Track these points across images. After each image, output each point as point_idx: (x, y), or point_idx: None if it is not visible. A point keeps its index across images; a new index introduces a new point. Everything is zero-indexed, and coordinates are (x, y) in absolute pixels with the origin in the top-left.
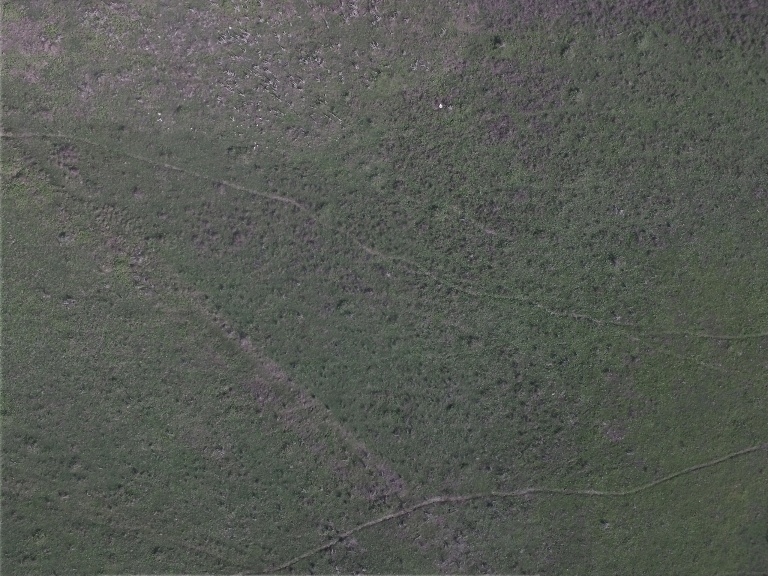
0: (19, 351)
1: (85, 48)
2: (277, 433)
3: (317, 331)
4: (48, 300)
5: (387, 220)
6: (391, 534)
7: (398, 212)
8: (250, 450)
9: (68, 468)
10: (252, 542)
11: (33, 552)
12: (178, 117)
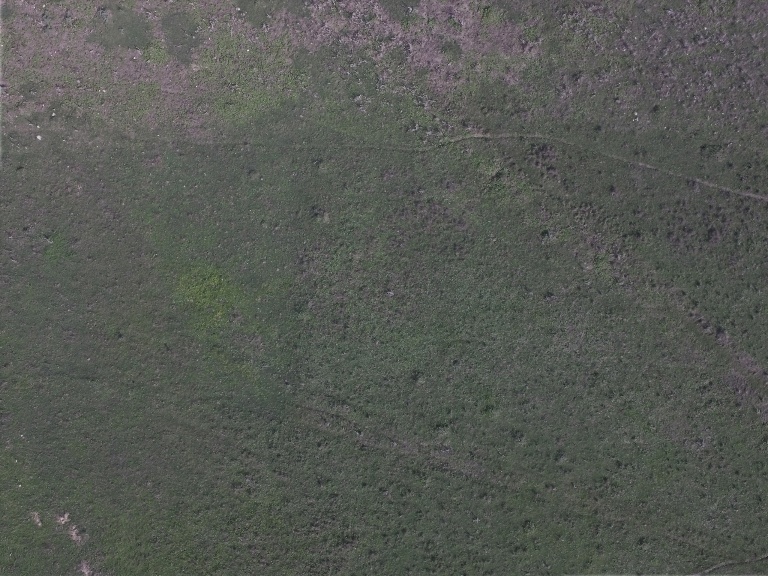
0: (503, 347)
1: (563, 50)
2: (757, 426)
3: None
4: (530, 297)
5: None
6: None
7: None
8: (729, 443)
9: (554, 461)
10: (734, 533)
11: (523, 543)
12: (654, 117)
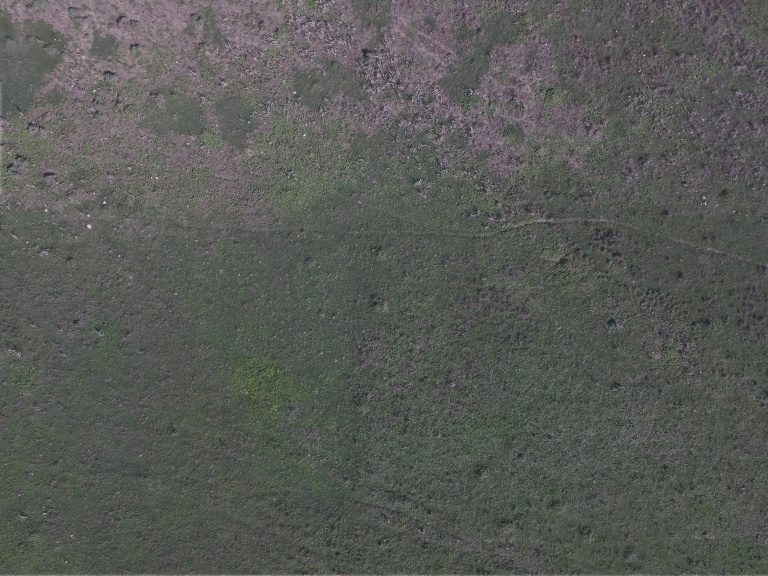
0: (569, 439)
1: (629, 132)
2: None
3: None
4: (596, 387)
5: None
6: None
7: None
8: None
9: (623, 558)
10: None
11: None
12: (722, 200)
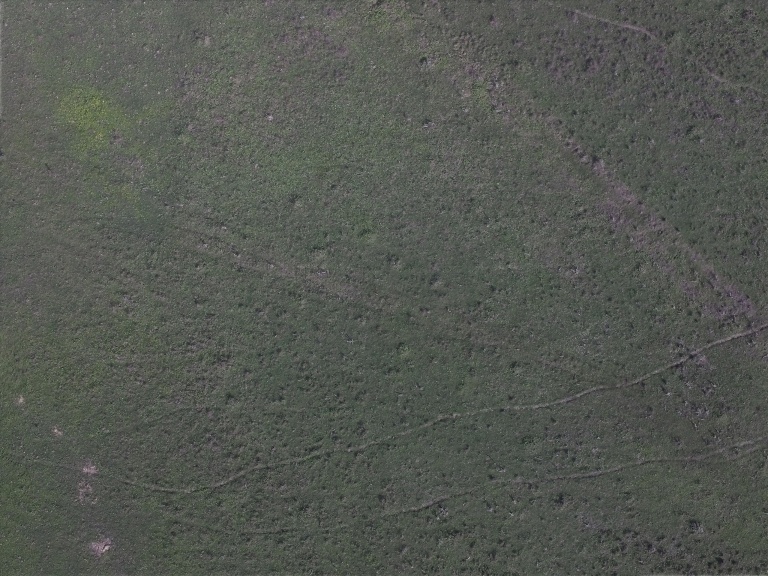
0: (381, 172)
1: None
2: (630, 253)
3: (667, 156)
4: (408, 124)
5: (735, 48)
6: (740, 352)
7: (746, 41)
8: (603, 270)
9: (429, 285)
10: (605, 358)
11: (397, 365)
12: None
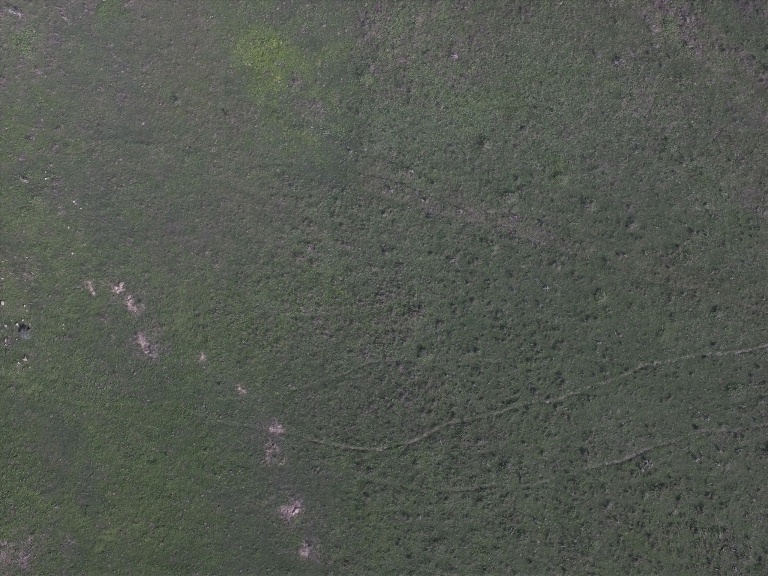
0: (571, 112)
1: None
2: None
3: None
4: (598, 61)
5: None
6: None
7: None
8: None
9: (625, 228)
10: None
11: (594, 311)
12: None
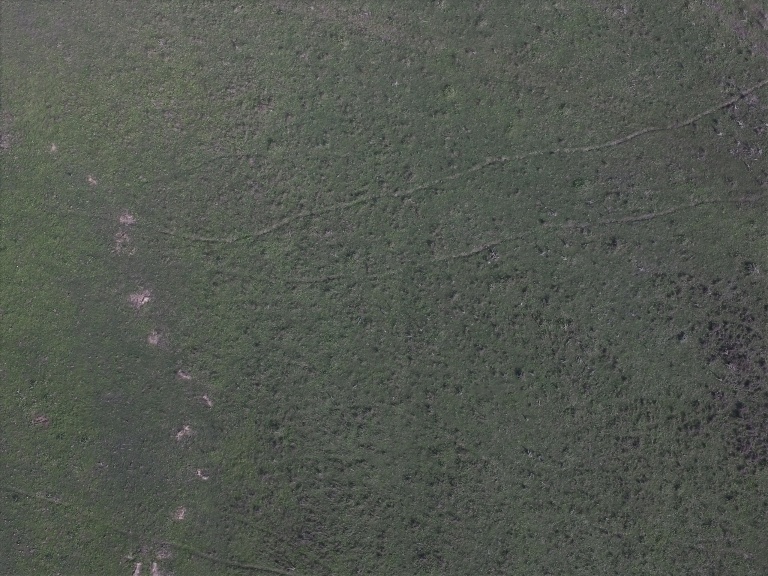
0: None
1: None
2: None
3: None
4: None
5: None
6: None
7: None
8: (651, 10)
9: (474, 26)
10: (655, 99)
11: (443, 107)
12: None
